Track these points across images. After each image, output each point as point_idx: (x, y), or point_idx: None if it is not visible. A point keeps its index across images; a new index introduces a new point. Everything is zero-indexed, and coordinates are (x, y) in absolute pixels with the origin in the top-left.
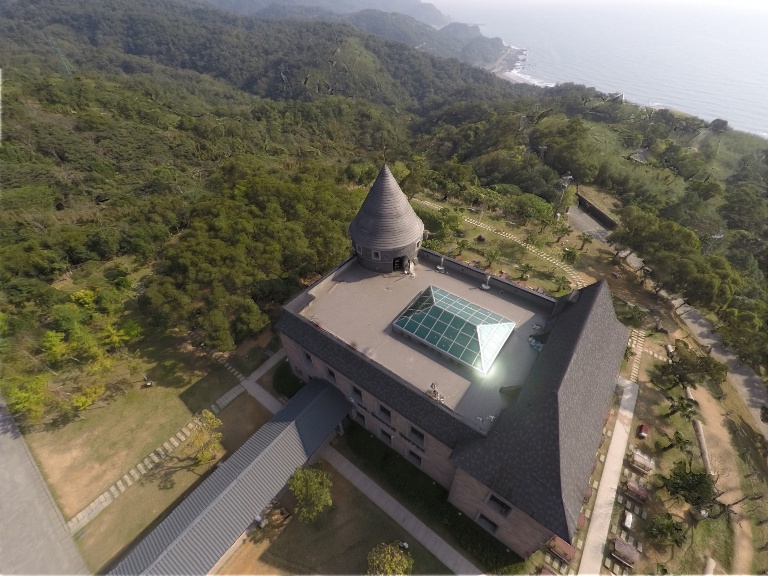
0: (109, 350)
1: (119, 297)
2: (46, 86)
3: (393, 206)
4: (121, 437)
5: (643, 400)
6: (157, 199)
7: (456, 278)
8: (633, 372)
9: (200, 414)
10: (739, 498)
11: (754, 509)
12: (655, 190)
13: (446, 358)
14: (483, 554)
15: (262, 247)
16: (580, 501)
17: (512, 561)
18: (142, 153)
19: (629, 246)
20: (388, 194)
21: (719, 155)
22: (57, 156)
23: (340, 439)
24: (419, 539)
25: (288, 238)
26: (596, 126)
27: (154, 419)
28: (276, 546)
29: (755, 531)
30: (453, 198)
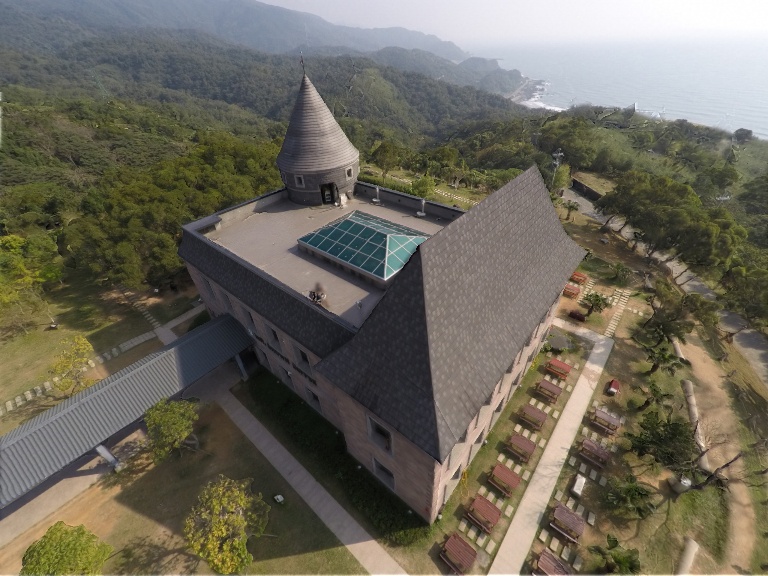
0: (18, 289)
1: (54, 247)
2: (77, 105)
3: (315, 122)
4: (2, 375)
5: (618, 356)
6: (125, 169)
7: (391, 208)
8: (609, 328)
9: (97, 356)
10: (738, 469)
11: (760, 484)
12: (661, 174)
13: (348, 271)
14: (376, 514)
15: (202, 195)
16: (469, 413)
17: (412, 524)
18: (154, 161)
19: (618, 209)
20: (309, 108)
21: (742, 158)
22: (73, 161)
23: (243, 385)
24: (302, 494)
25: (232, 189)
26: (603, 126)
27: (45, 359)
28: (126, 493)
29: (759, 510)
30: (434, 176)
